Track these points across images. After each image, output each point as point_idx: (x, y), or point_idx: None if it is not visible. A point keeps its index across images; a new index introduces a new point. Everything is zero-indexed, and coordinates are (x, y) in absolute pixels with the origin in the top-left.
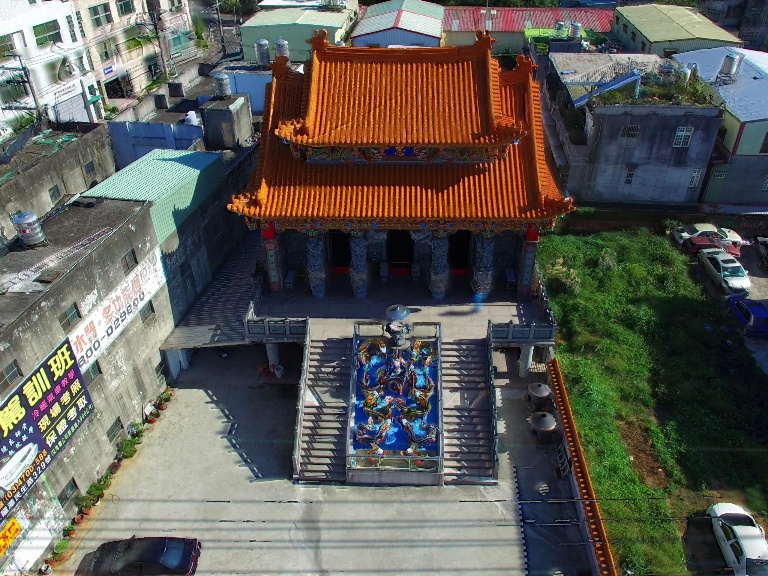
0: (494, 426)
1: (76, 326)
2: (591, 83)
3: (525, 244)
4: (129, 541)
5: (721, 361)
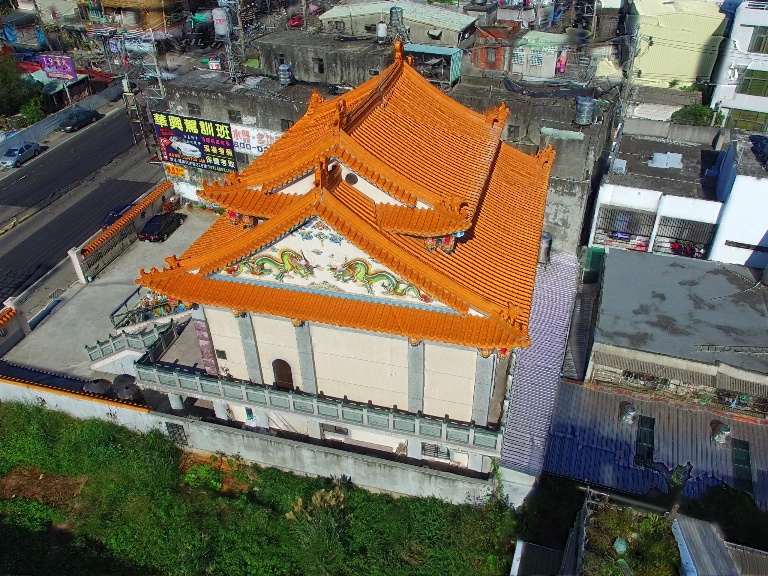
0: None
1: (238, 124)
2: None
3: None
4: (171, 216)
5: None
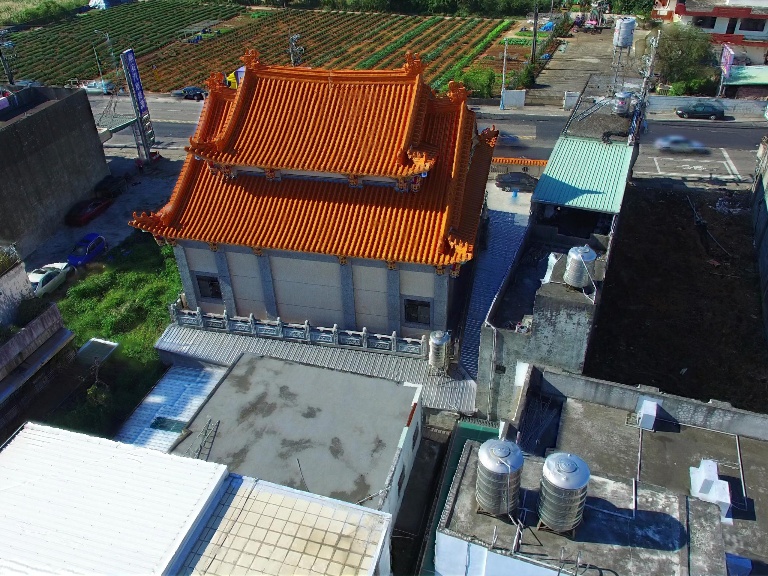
0: None
1: None
2: None
3: None
4: None
5: None
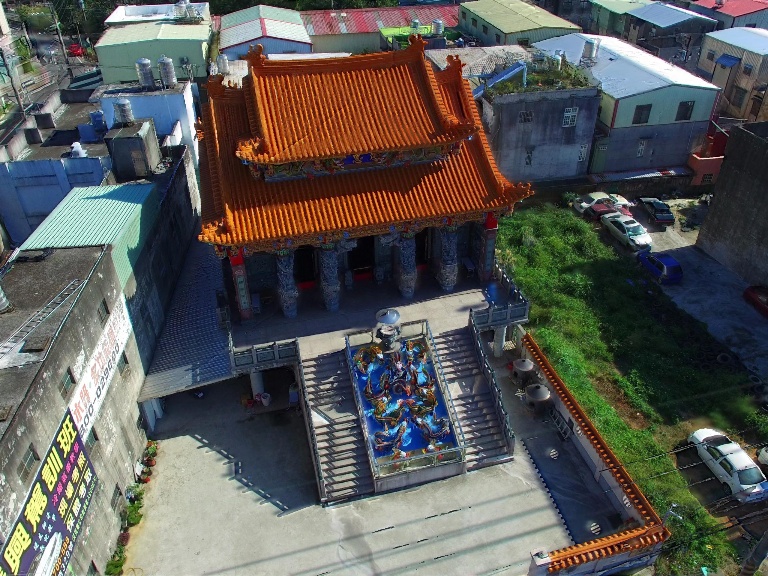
0: (501, 406)
1: (73, 393)
2: (475, 76)
3: (486, 232)
4: None
5: (652, 310)
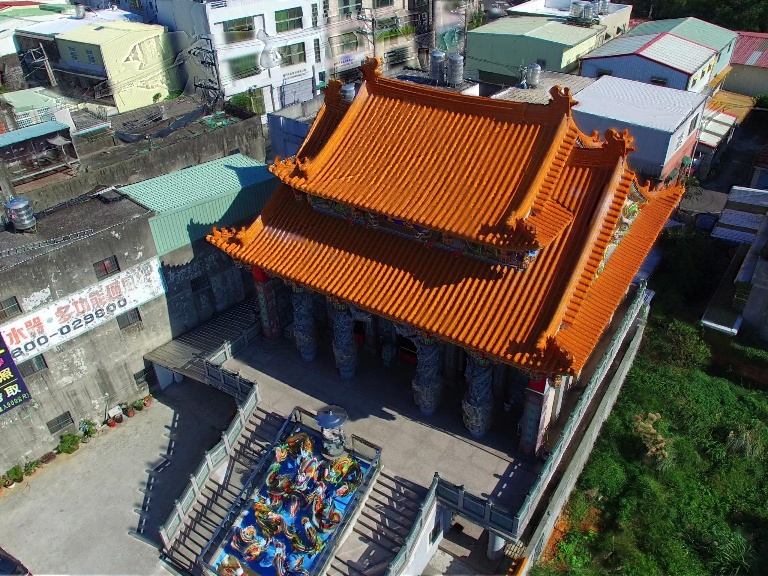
0: None
1: (13, 319)
2: None
3: (527, 390)
4: None
5: None
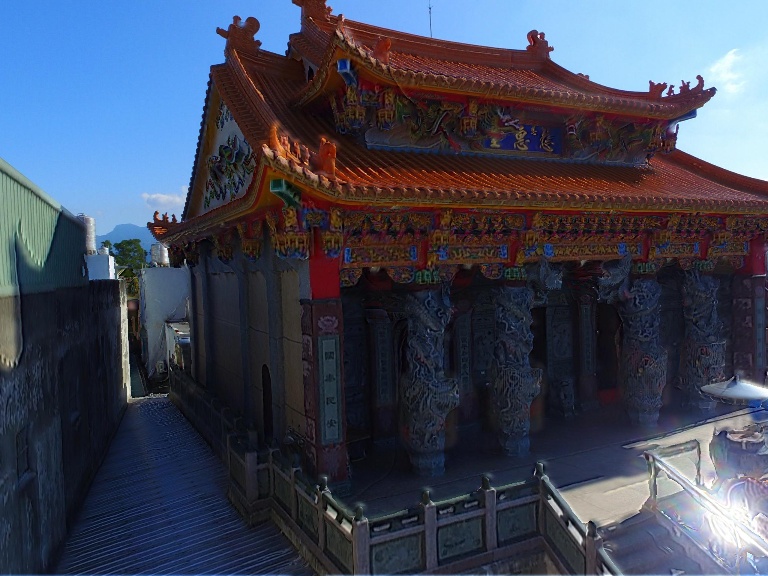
0: None
1: None
2: None
3: (752, 281)
4: None
5: None
